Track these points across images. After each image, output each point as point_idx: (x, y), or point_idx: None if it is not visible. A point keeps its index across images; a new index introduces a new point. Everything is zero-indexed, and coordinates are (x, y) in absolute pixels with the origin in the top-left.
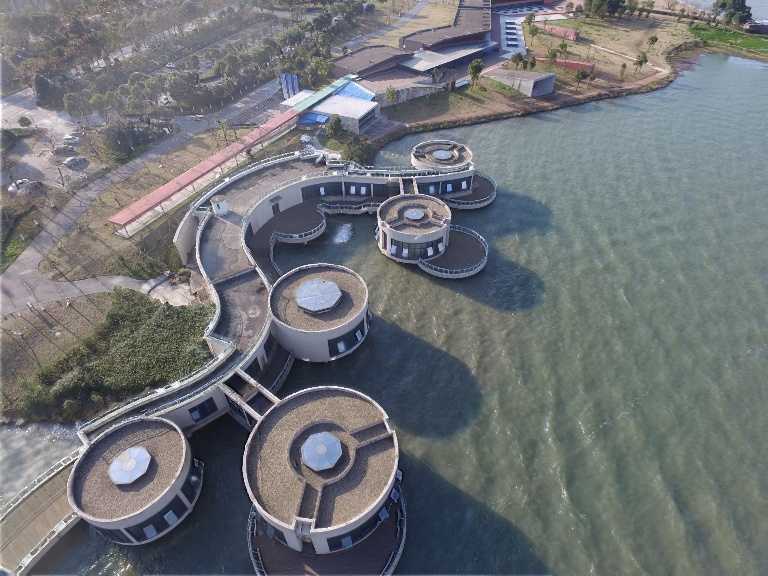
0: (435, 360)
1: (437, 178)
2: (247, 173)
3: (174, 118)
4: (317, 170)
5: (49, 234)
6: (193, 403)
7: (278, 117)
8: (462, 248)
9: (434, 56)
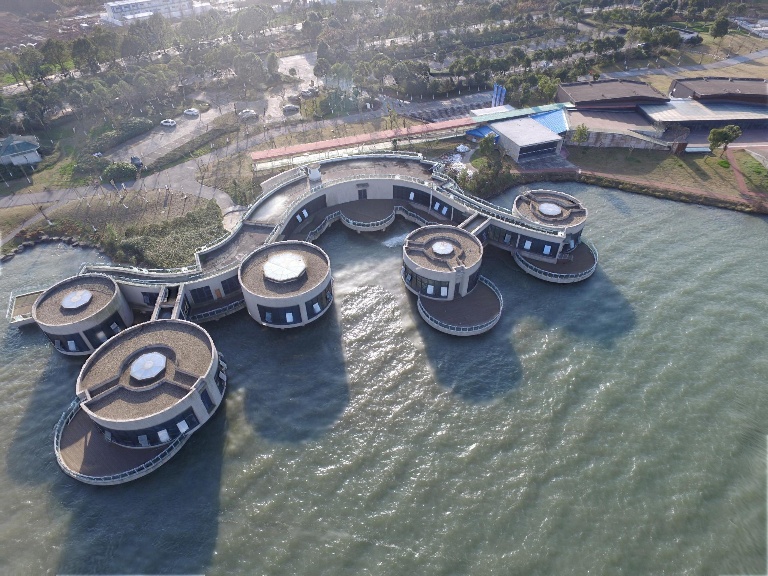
0: (332, 379)
1: (515, 228)
2: (367, 156)
3: (386, 98)
4: (421, 176)
5: (226, 150)
6: (143, 289)
7: (451, 121)
8: (474, 306)
9: (696, 109)
